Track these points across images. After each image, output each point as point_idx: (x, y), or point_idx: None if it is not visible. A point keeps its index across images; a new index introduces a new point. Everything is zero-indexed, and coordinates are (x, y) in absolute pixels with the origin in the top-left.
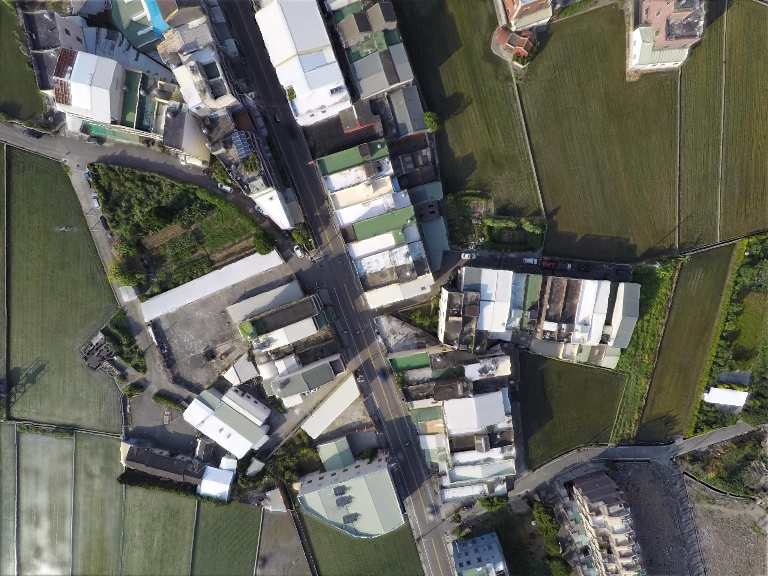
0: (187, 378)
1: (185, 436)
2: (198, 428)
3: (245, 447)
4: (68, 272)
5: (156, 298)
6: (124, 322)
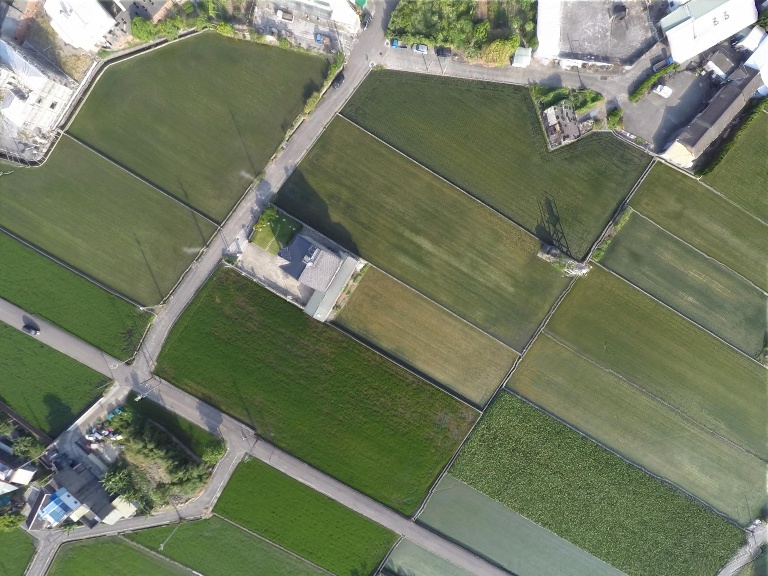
0: (631, 51)
1: (690, 89)
2: (697, 52)
3: (748, 2)
4: (471, 122)
5: (539, 30)
6: (544, 87)
